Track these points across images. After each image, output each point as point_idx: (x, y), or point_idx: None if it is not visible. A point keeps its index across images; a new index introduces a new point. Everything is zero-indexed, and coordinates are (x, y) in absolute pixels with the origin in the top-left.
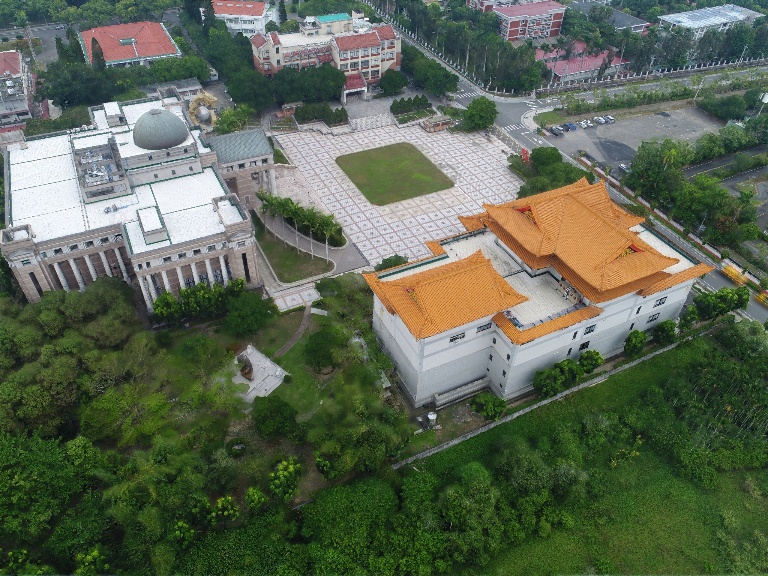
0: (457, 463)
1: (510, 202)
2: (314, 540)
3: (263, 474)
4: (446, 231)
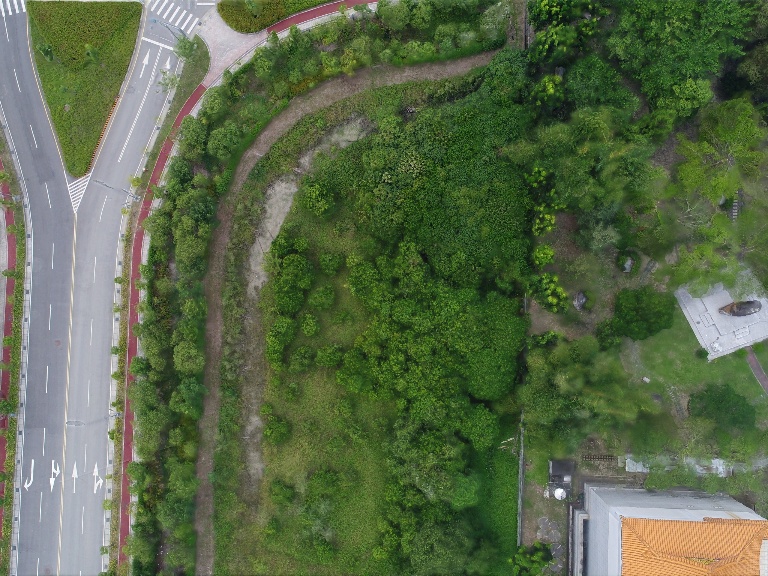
0: (496, 487)
1: None
2: (483, 300)
3: None
4: None
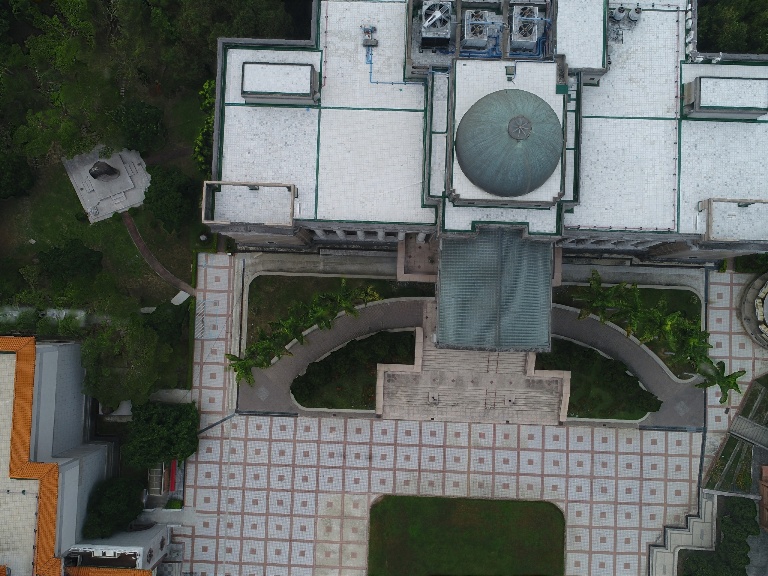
0: None
1: None
2: None
3: None
4: (255, 570)
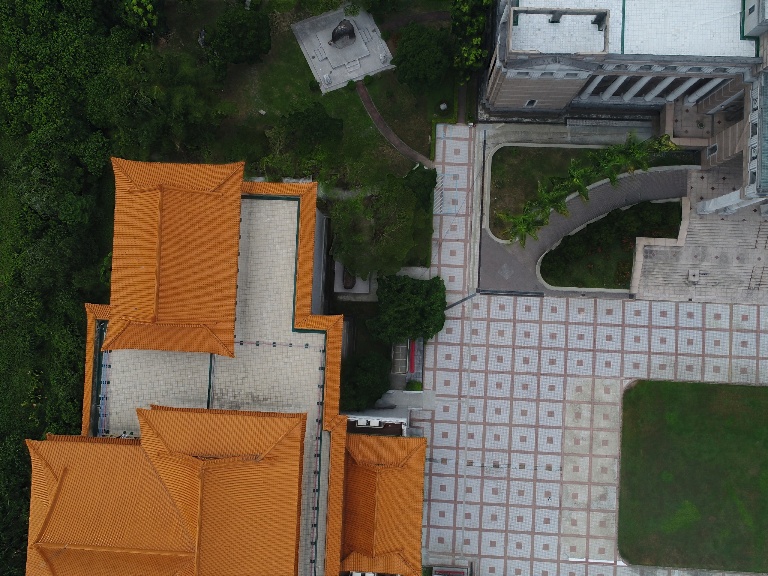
0: None
1: (294, 476)
2: None
3: (188, 6)
4: (499, 456)
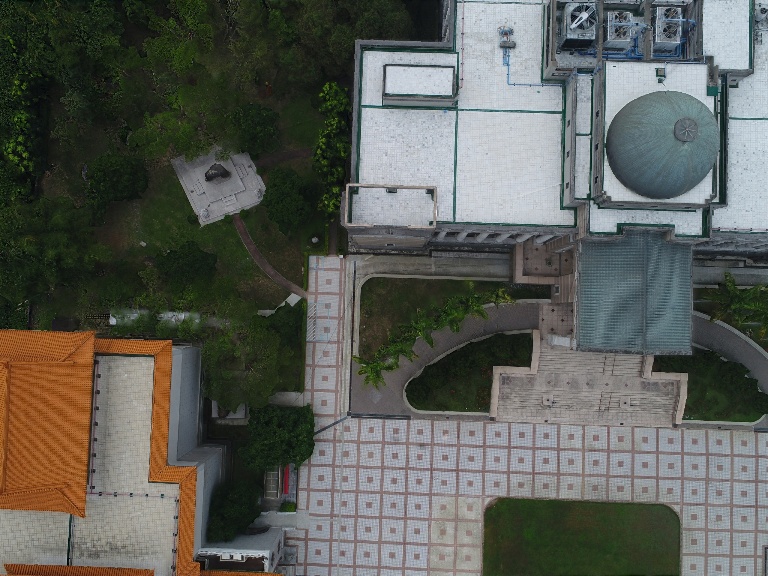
0: None
1: None
2: None
3: None
4: (369, 573)
